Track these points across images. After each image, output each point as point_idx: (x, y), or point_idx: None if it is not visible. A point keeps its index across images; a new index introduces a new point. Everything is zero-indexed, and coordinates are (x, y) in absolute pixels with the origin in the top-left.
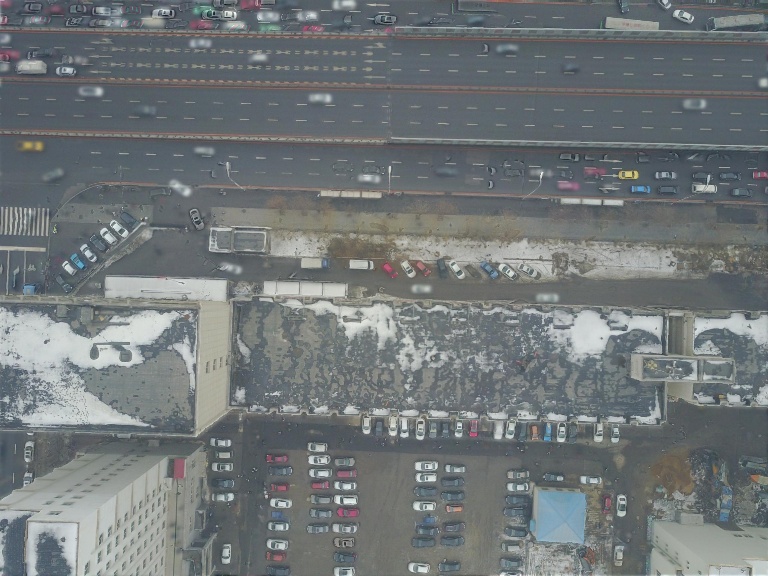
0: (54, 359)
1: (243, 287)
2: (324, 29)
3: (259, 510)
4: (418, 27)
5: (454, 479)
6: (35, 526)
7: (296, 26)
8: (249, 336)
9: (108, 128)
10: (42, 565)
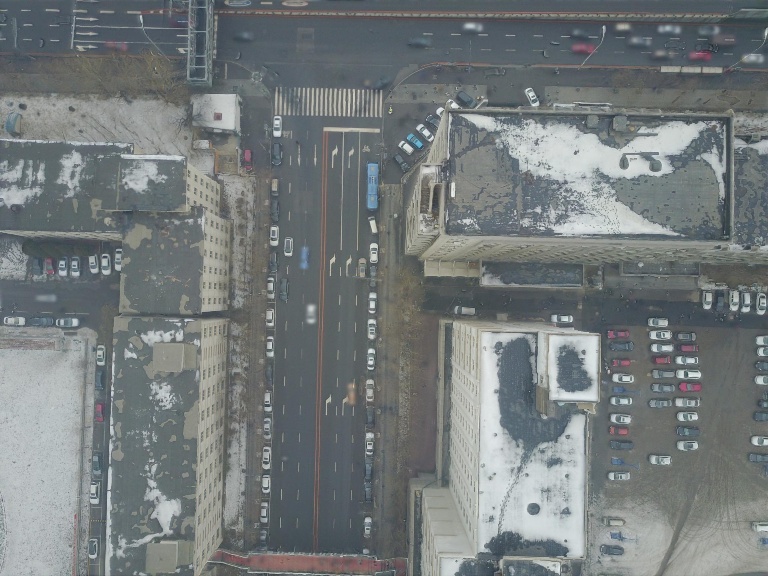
0: (585, 169)
1: None
2: None
3: None
4: None
5: None
6: (555, 339)
7: None
8: None
9: (442, 8)
10: (563, 377)
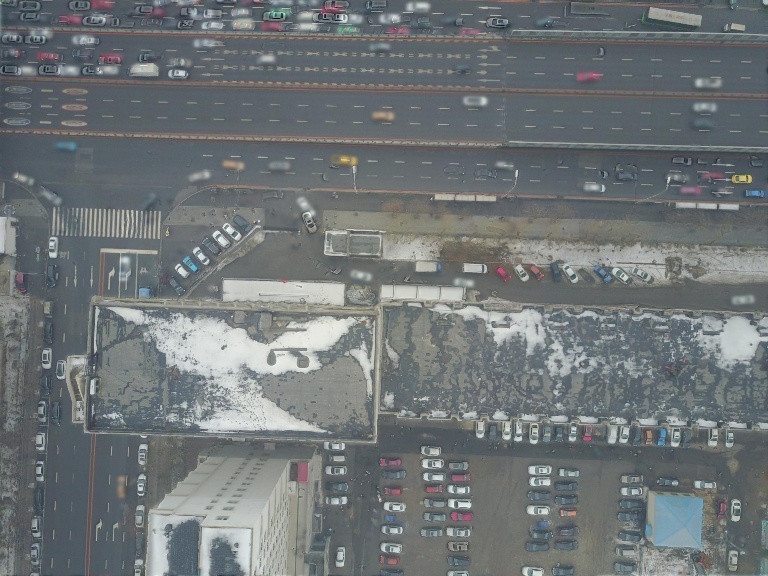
0: (232, 365)
1: (356, 290)
2: (437, 32)
3: (372, 513)
4: (536, 30)
5: (568, 483)
6: (208, 531)
7: (409, 29)
8: (398, 341)
9: (221, 131)
10: (216, 570)
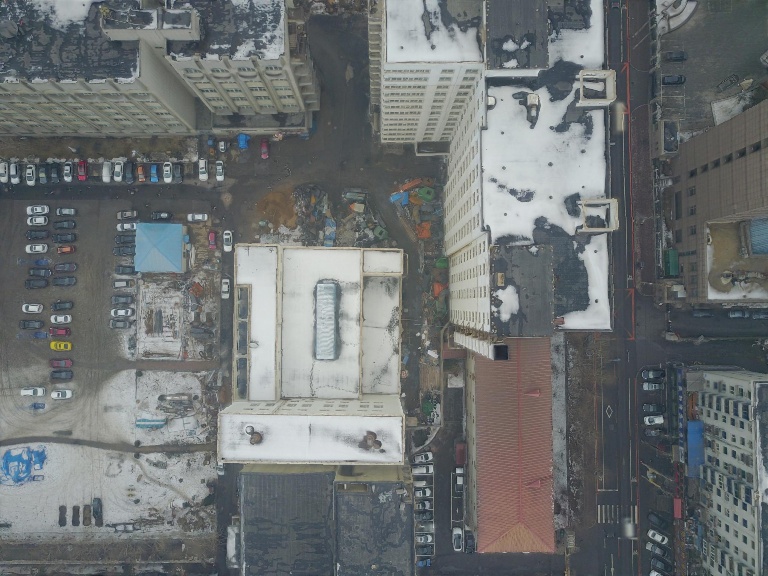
0: None
1: None
2: None
3: None
4: None
5: (63, 221)
6: None
7: None
8: None
9: None
10: None
